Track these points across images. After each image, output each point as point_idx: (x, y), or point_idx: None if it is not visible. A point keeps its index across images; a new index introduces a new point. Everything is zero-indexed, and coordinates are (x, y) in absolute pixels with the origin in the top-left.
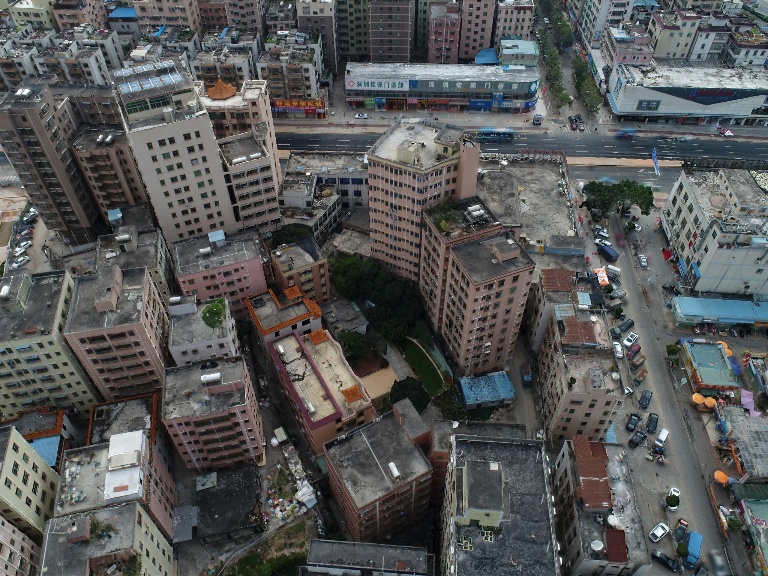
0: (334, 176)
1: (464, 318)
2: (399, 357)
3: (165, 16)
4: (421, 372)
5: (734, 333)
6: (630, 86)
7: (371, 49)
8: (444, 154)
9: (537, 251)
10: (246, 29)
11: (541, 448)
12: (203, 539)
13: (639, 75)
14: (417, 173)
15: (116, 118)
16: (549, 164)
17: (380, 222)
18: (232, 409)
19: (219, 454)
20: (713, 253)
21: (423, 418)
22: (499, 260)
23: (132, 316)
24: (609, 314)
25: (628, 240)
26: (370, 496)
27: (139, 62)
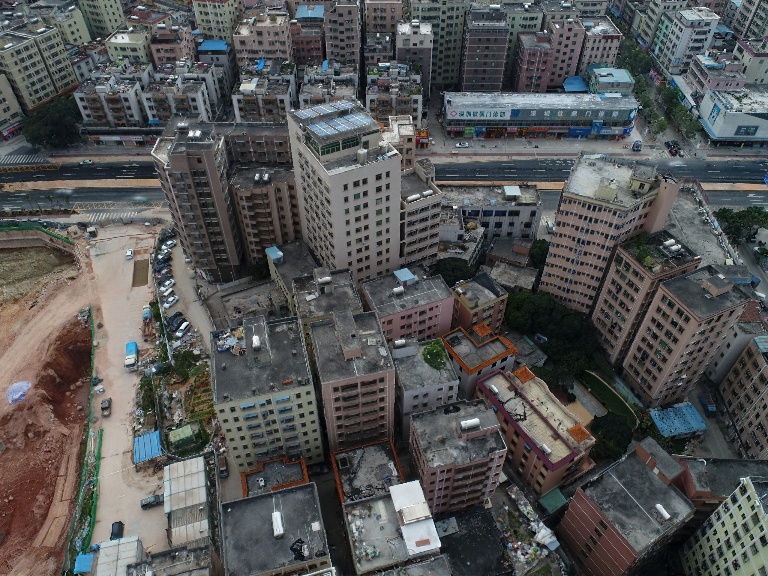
0: (478, 209)
1: (672, 352)
2: (583, 391)
3: (264, 49)
4: (609, 405)
5: None
6: (731, 112)
7: (464, 79)
8: (639, 190)
9: None
10: (344, 61)
11: None
12: None
13: (734, 101)
14: (619, 210)
15: (267, 156)
16: (682, 192)
17: (560, 257)
18: (493, 455)
19: (460, 499)
20: None
21: (626, 453)
22: (713, 295)
23: (379, 362)
24: None
25: (761, 265)
26: (643, 539)
27: (248, 96)
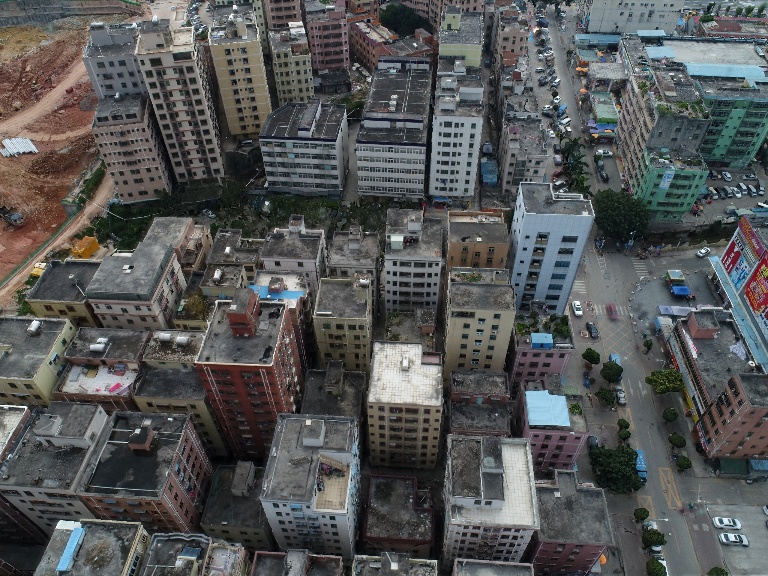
0: None
1: None
2: None
3: None
4: None
5: (608, 51)
6: None
7: None
8: None
9: None
10: None
11: (480, 15)
12: (324, 88)
13: None
14: None
15: None
16: None
17: None
18: (340, 21)
19: (330, 58)
20: (594, 1)
21: None
22: None
23: None
24: (539, 46)
25: (557, 20)
26: None
27: None
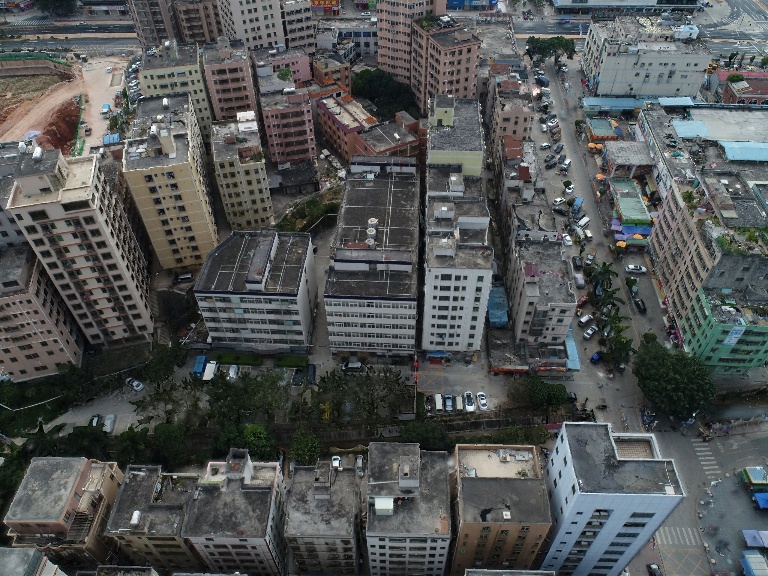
0: (350, 30)
1: (439, 82)
2: None
3: None
4: None
5: (622, 118)
6: None
7: None
8: None
9: (489, 63)
10: None
11: (477, 103)
12: (285, 189)
13: None
14: None
15: None
16: (501, 24)
17: (384, 38)
18: (302, 107)
19: (292, 149)
20: (605, 61)
21: None
22: (459, 40)
23: None
24: (540, 112)
25: (558, 76)
26: None
27: None
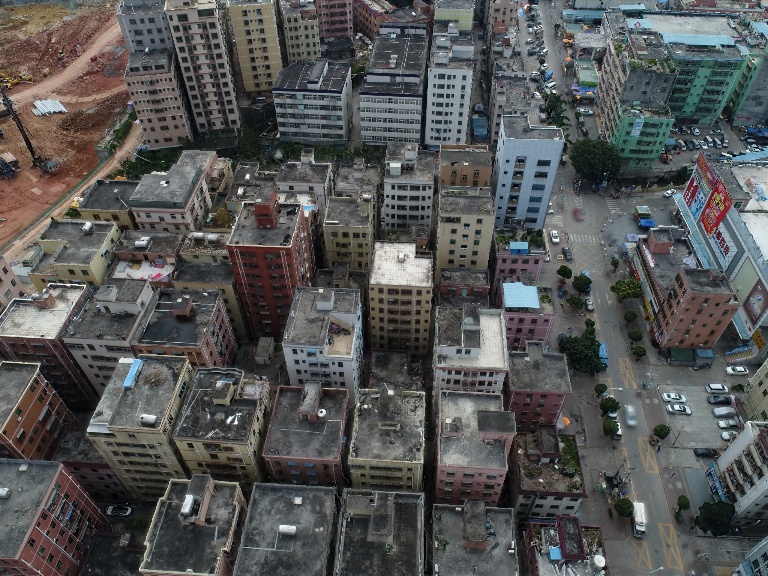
0: None
1: None
2: None
3: None
4: None
5: (593, 25)
6: None
7: None
8: None
9: None
10: None
11: None
12: (330, 54)
13: None
14: None
15: None
16: None
17: None
18: None
19: (335, 27)
20: None
21: None
22: None
23: None
24: (529, 21)
25: None
26: None
27: None
